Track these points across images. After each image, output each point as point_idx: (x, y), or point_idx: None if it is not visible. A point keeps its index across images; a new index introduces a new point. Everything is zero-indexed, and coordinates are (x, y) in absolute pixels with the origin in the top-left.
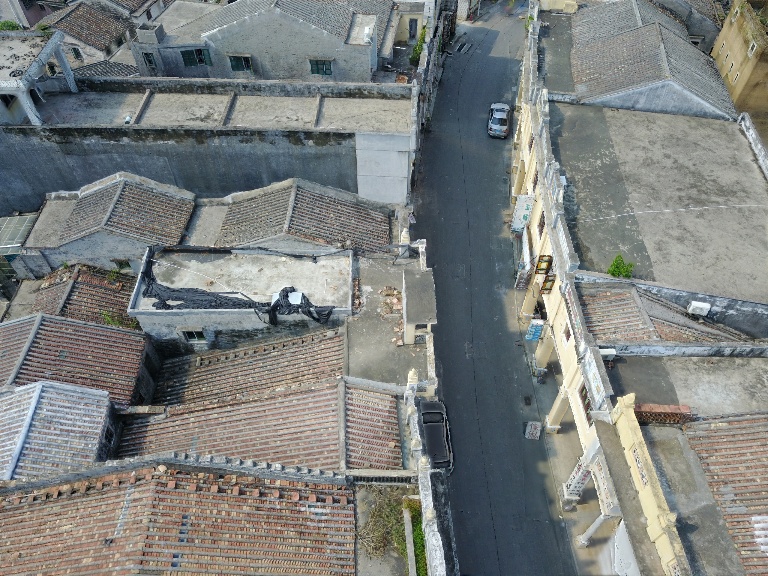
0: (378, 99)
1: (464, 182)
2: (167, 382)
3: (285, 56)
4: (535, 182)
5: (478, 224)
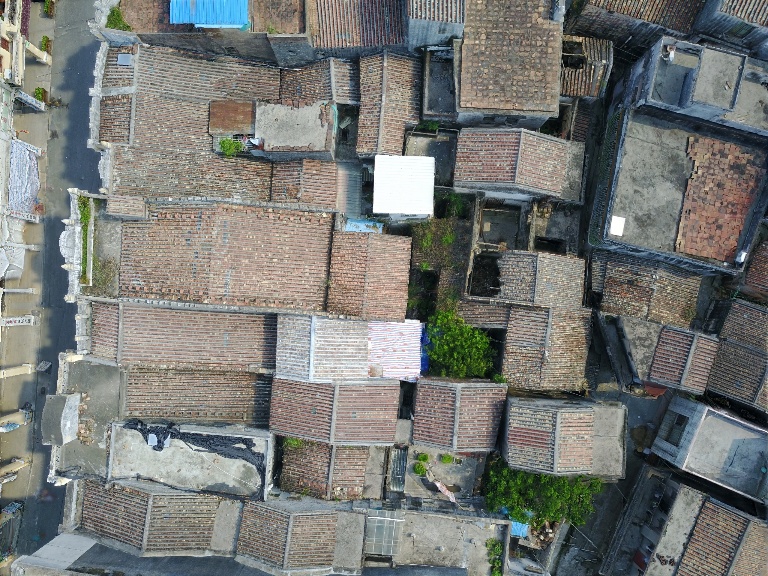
0: None
1: None
2: (269, 405)
3: None
4: None
5: None
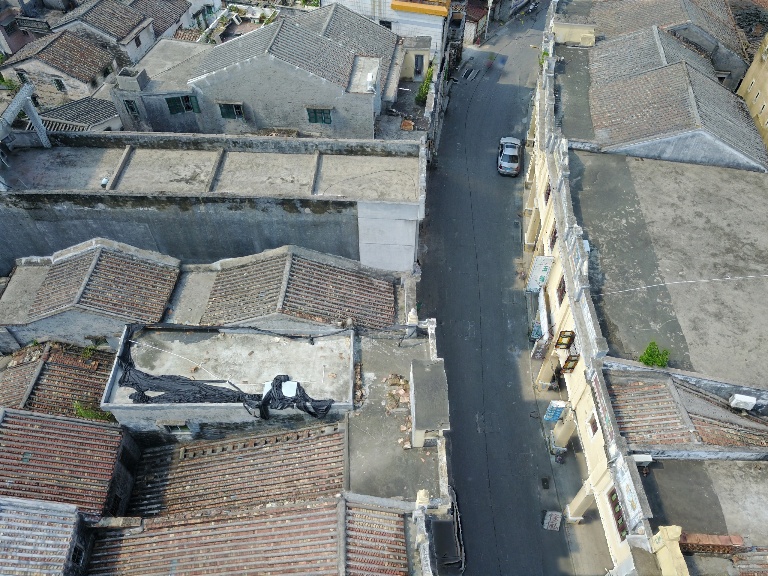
0: (382, 156)
1: (473, 226)
2: (147, 476)
3: (280, 104)
4: (553, 240)
5: (488, 274)
